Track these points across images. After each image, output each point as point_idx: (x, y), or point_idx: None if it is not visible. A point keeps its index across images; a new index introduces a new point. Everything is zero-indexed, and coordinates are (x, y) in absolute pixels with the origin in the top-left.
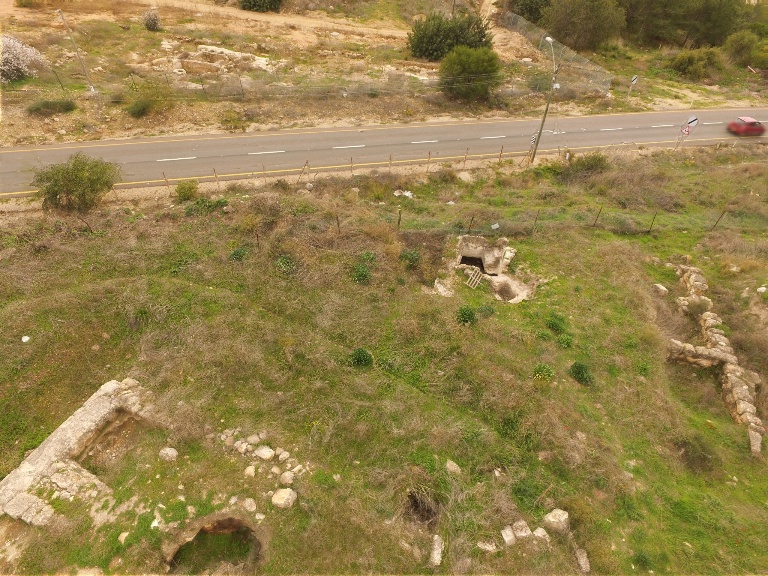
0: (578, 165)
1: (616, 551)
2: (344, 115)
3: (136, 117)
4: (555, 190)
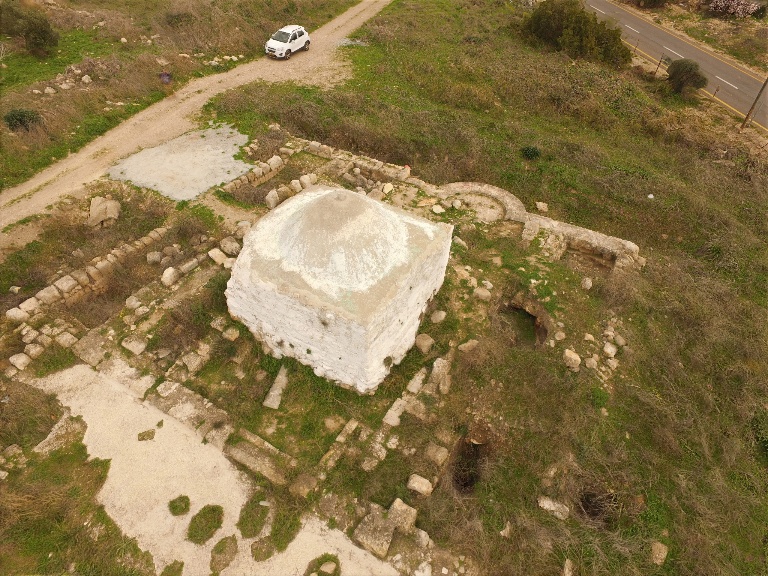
0: None
1: None
2: None
3: None
4: None
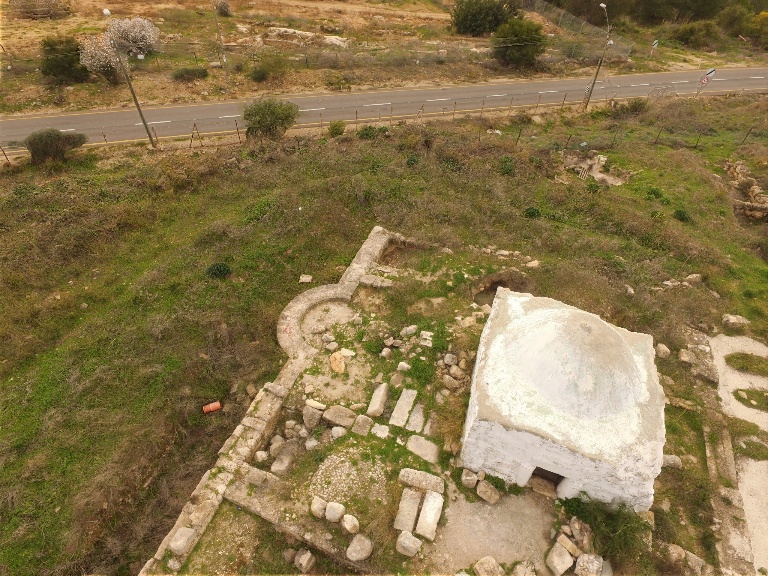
0: (623, 109)
1: (732, 291)
2: (421, 78)
3: (258, 81)
4: (616, 123)
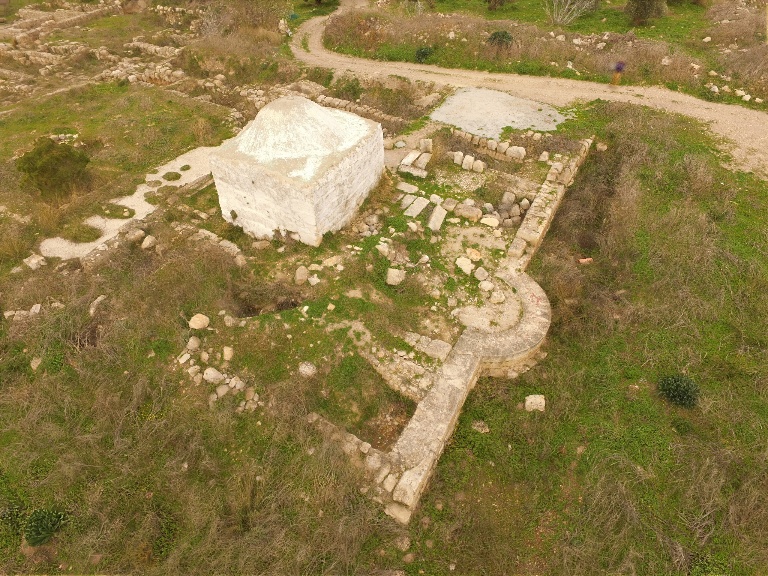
0: None
1: None
2: None
3: None
4: None
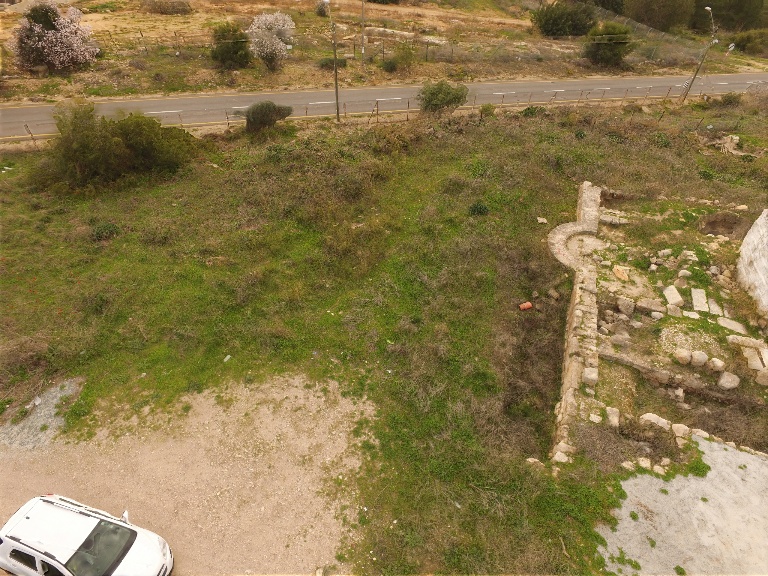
0: (717, 103)
1: None
2: (526, 73)
3: (389, 72)
4: (725, 111)
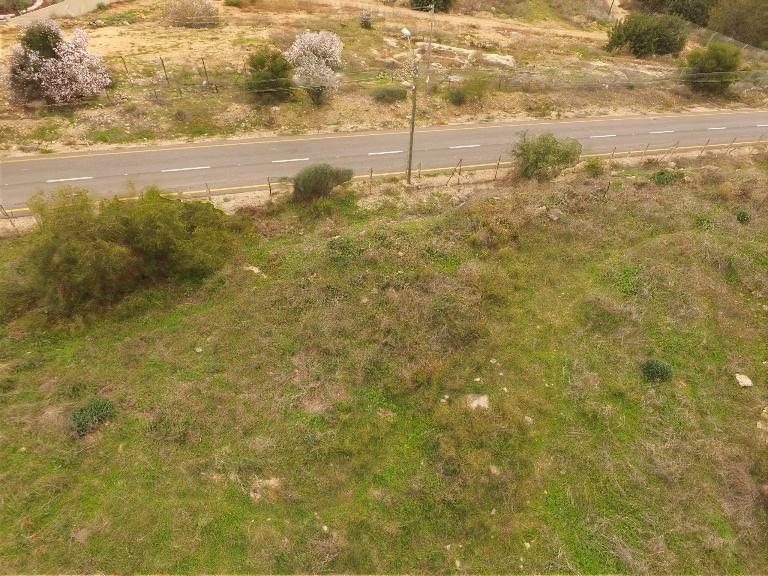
0: None
1: None
2: (617, 105)
3: (457, 105)
4: None
